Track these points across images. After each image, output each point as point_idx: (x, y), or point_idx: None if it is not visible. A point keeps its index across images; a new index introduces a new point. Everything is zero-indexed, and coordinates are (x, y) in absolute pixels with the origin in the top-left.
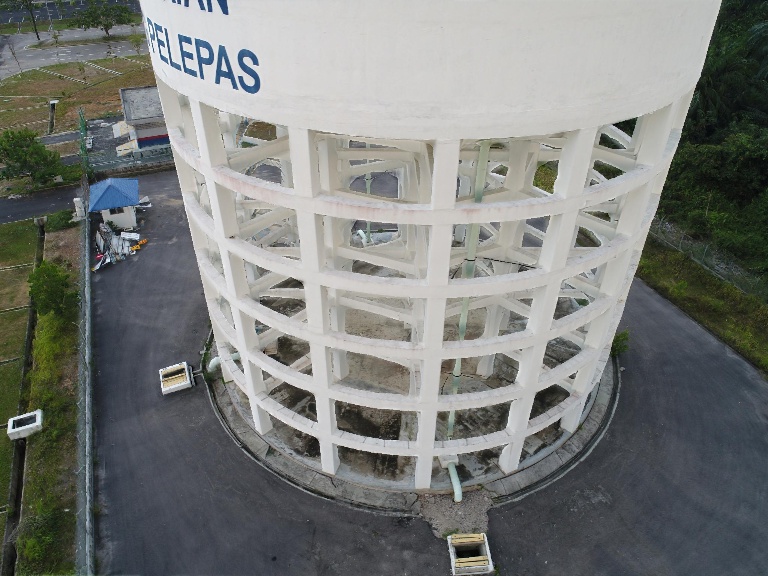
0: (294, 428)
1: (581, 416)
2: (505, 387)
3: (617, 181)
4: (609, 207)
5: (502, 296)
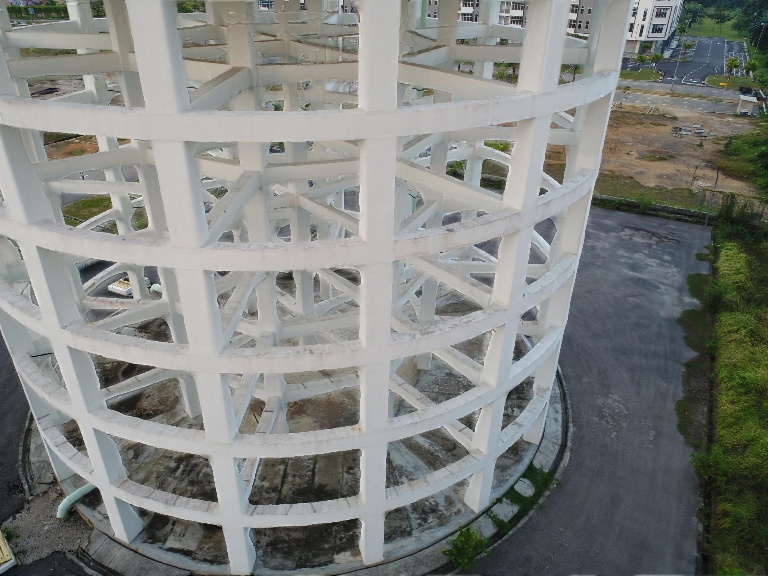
0: (101, 361)
1: (274, 570)
2: (66, 391)
3: (58, 104)
4: (481, 295)
5: (262, 331)
